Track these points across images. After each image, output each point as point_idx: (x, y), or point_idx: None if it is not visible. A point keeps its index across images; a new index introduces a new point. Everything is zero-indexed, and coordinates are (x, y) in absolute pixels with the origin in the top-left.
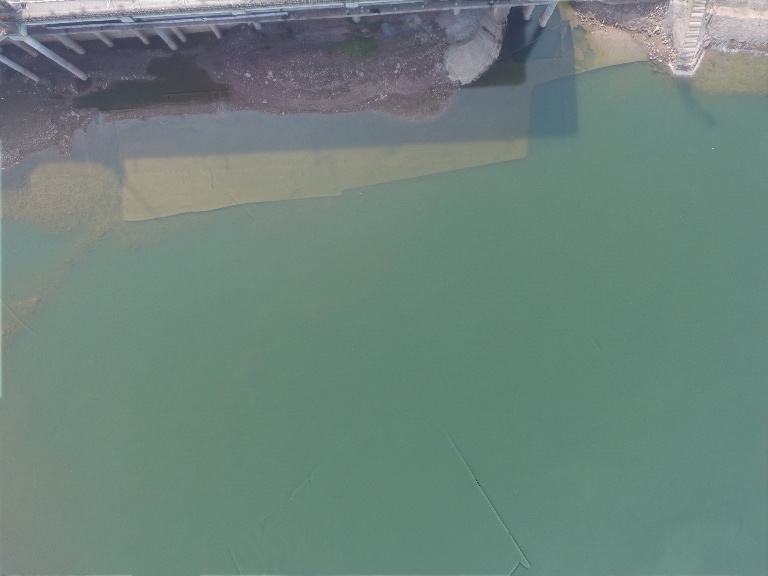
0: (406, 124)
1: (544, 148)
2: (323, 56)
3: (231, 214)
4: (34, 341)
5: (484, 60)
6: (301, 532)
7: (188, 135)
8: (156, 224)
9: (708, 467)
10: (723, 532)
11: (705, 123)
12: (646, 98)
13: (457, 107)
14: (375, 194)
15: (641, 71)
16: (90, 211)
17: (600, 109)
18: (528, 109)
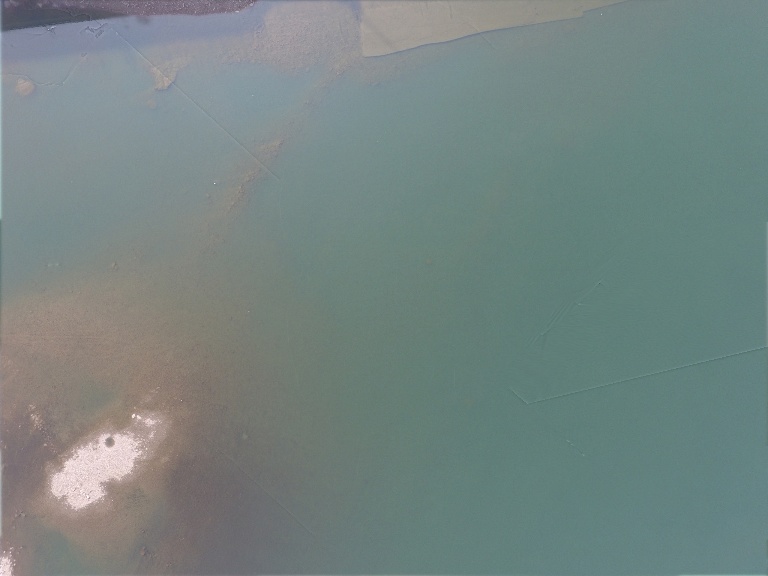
0: None
1: None
2: None
3: (471, 44)
4: (278, 186)
5: None
6: (599, 332)
7: None
8: (395, 59)
9: None
10: None
11: None
12: None
13: None
14: (615, 14)
15: None
16: (328, 50)
17: None
18: None
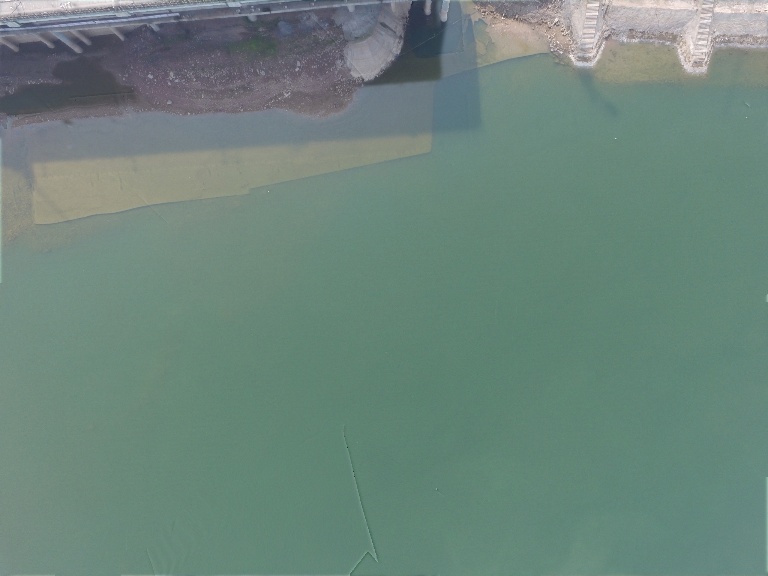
0: (311, 122)
1: (448, 142)
2: (222, 56)
3: (141, 215)
4: None
5: (385, 56)
6: (204, 527)
7: (96, 138)
8: (67, 227)
9: (615, 455)
10: (633, 519)
11: (607, 113)
12: (548, 90)
13: (361, 103)
14: (282, 192)
15: (543, 63)
16: (1, 215)
17: (503, 102)
18: (431, 104)
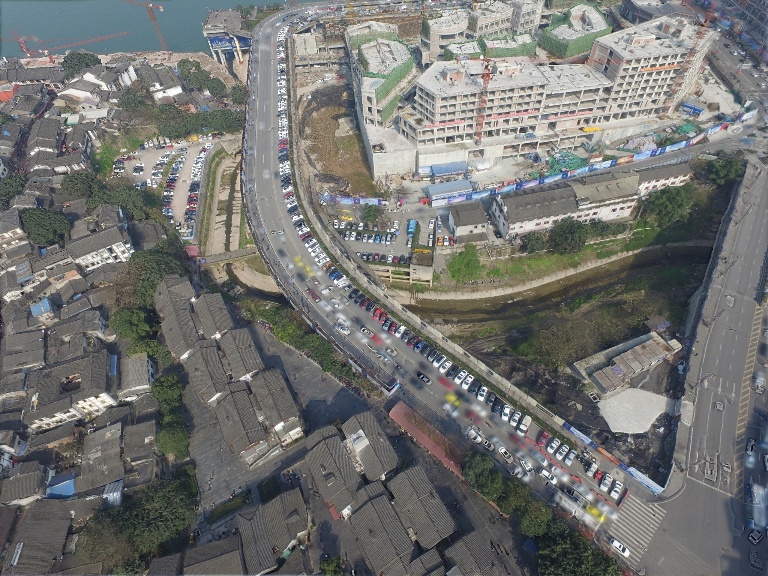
0: None
1: None
2: None
3: None
4: None
5: None
6: None
7: None
8: None
9: None
10: None
11: (163, 44)
12: None
13: None
14: None
15: (184, 52)
16: None
17: None
18: None
